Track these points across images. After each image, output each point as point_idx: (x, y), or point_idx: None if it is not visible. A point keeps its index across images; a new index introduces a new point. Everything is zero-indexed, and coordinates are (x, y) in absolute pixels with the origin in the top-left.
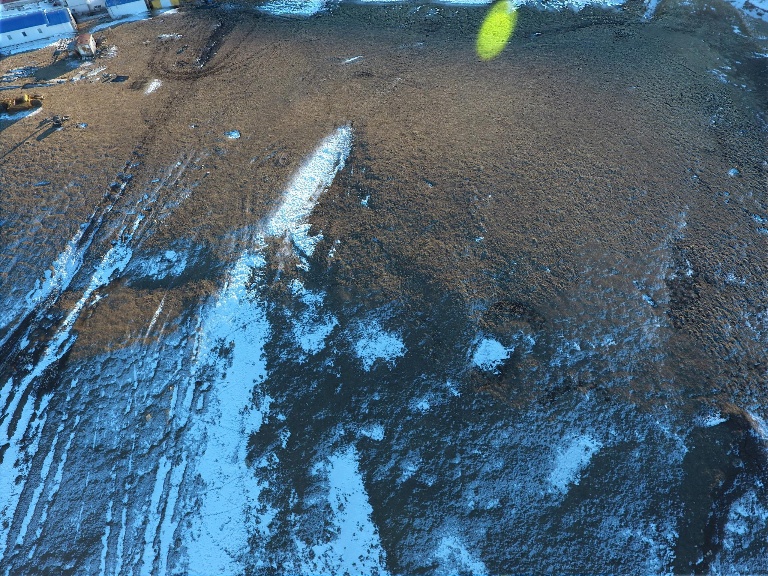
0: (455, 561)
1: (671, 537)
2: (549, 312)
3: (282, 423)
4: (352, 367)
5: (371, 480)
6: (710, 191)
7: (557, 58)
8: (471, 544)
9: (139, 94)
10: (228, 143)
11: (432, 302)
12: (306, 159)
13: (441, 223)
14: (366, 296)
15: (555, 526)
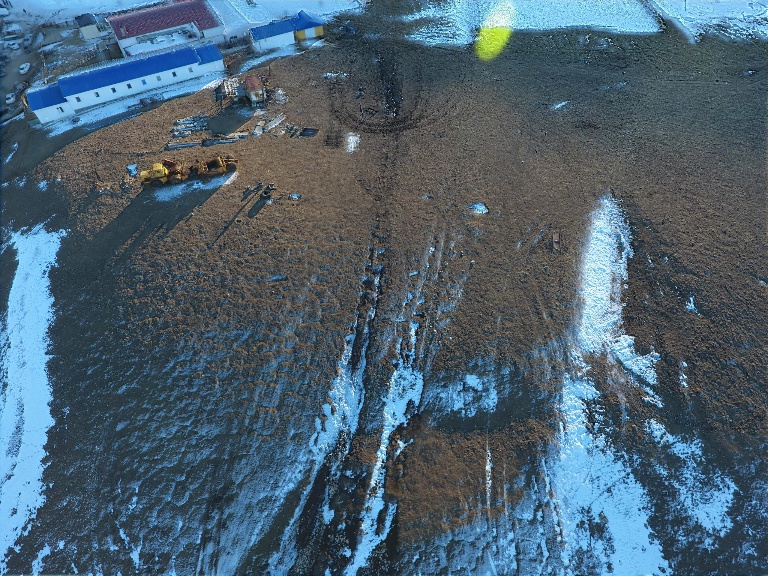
0: None
1: None
2: None
3: None
4: None
5: None
6: None
7: None
8: None
9: (342, 153)
10: (479, 220)
11: None
12: (584, 243)
13: None
14: (760, 448)
15: None
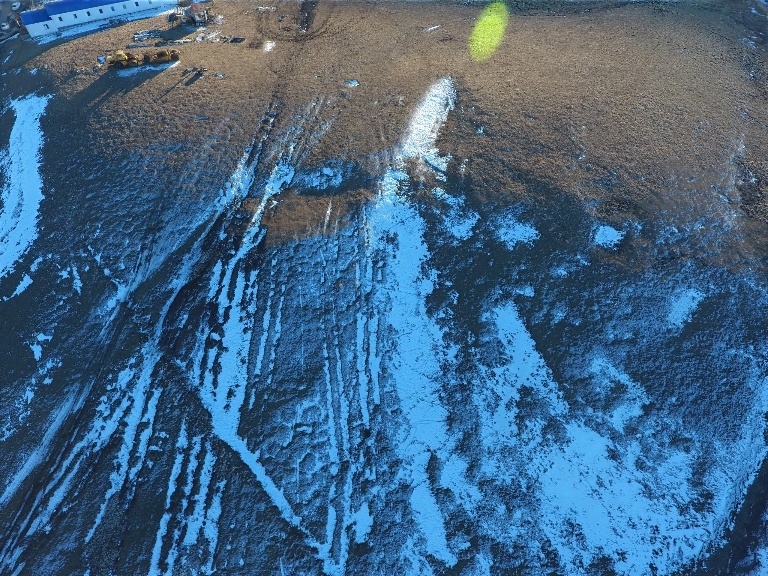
0: (606, 374)
1: (766, 353)
2: (649, 207)
3: (450, 287)
4: (499, 247)
5: (530, 323)
6: (759, 124)
7: (611, 27)
8: (616, 362)
9: (259, 52)
10: (351, 89)
11: (554, 201)
12: (421, 101)
13: (548, 146)
14: (499, 198)
15: (678, 349)
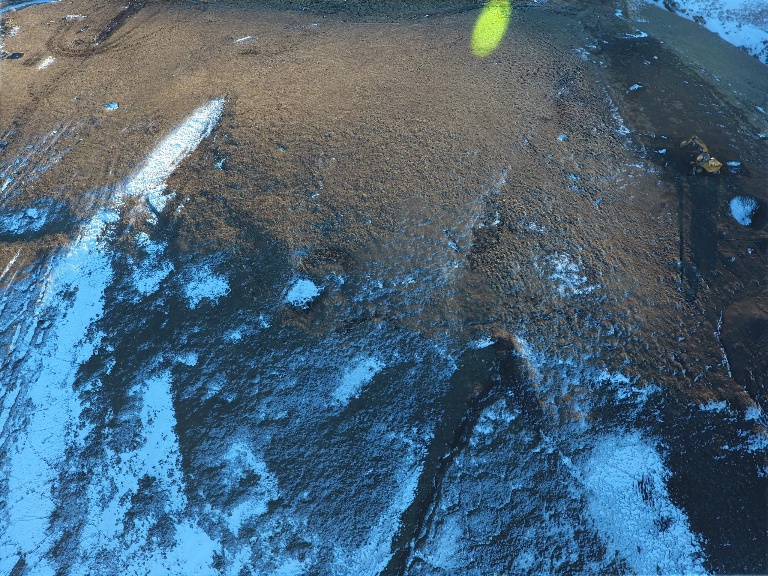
0: (241, 462)
1: (428, 438)
2: (362, 256)
3: (110, 354)
4: (179, 305)
5: (179, 398)
6: (535, 153)
7: (435, 37)
8: (257, 448)
9: (30, 70)
10: (105, 113)
11: (260, 249)
12: (175, 127)
13: (284, 182)
14: (202, 245)
15: (331, 432)
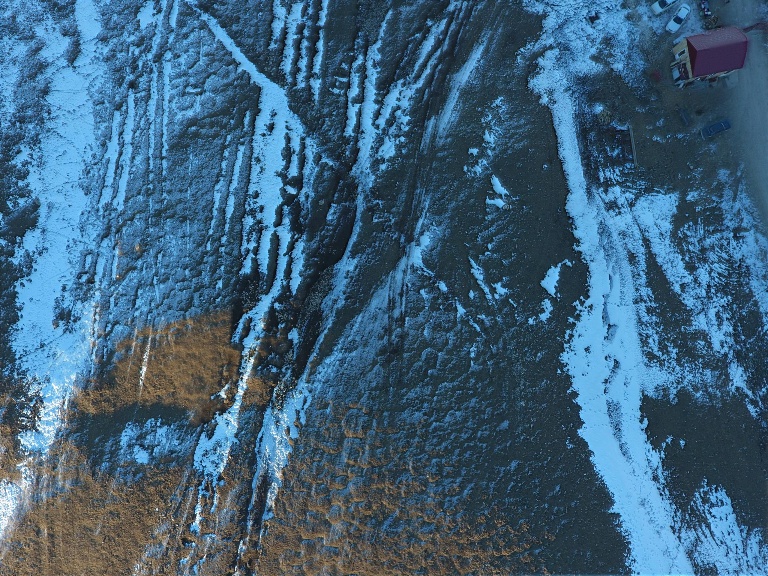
0: None
1: None
2: None
3: (1, 236)
4: None
5: None
6: None
7: None
8: None
9: None
10: None
11: None
12: None
13: None
14: None
15: None
